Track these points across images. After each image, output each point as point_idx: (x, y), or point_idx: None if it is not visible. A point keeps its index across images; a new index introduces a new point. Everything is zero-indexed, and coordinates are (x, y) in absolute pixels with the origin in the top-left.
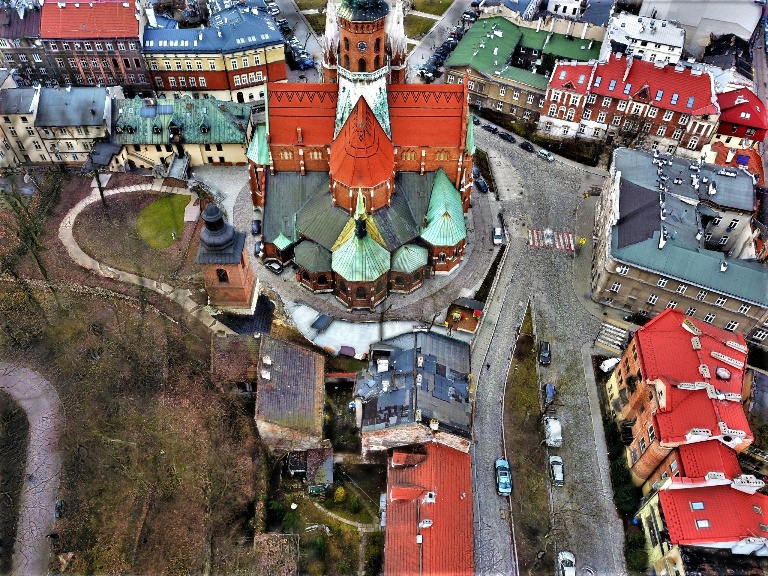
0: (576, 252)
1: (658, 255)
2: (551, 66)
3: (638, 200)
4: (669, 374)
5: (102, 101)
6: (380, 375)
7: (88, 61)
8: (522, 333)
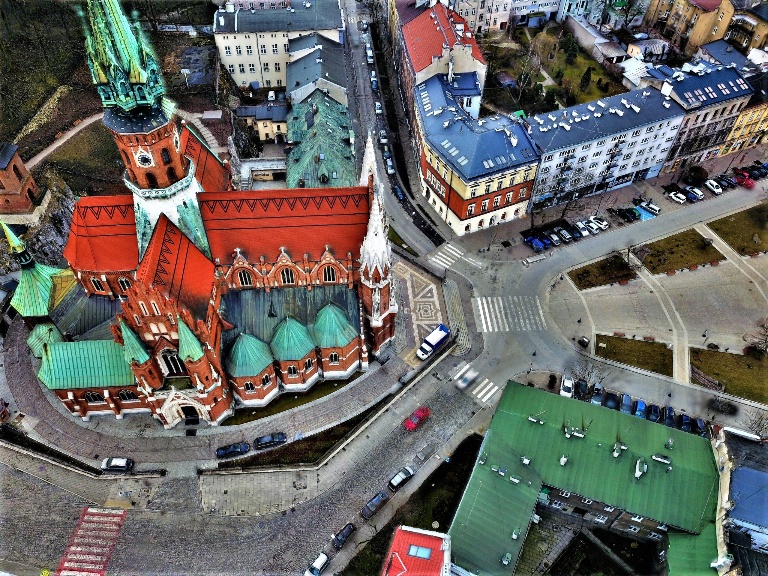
0: (54, 575)
1: None
2: None
3: None
4: None
5: None
6: None
7: None
8: None
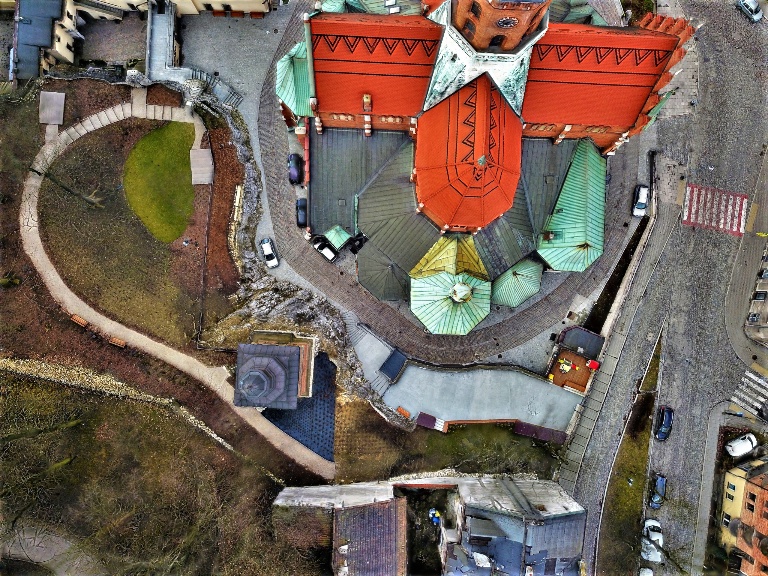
0: (745, 238)
1: None
2: None
3: None
4: None
5: None
6: None
7: None
8: (643, 390)
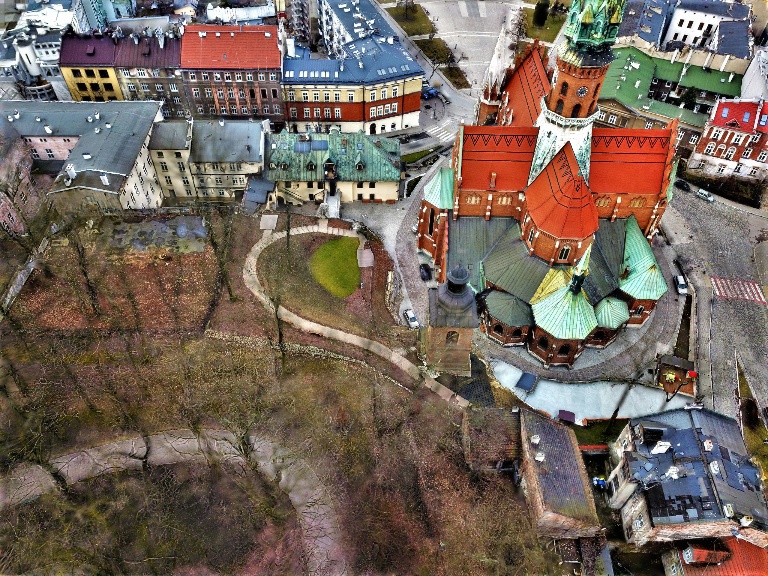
0: None
1: None
2: (693, 100)
3: None
4: None
5: (257, 136)
6: (655, 457)
7: (225, 91)
8: (742, 397)
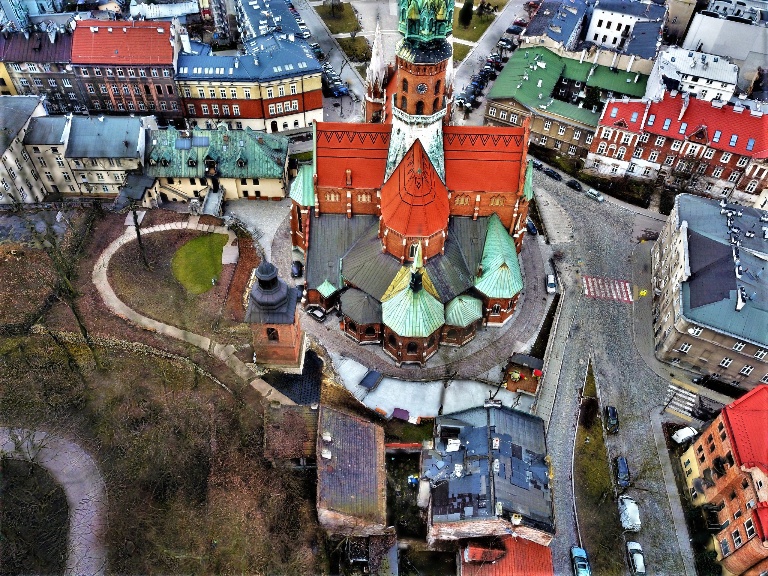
0: (635, 303)
1: (735, 317)
2: (596, 100)
3: (709, 254)
4: (767, 462)
5: (136, 132)
6: (449, 455)
7: (119, 87)
8: (586, 396)
